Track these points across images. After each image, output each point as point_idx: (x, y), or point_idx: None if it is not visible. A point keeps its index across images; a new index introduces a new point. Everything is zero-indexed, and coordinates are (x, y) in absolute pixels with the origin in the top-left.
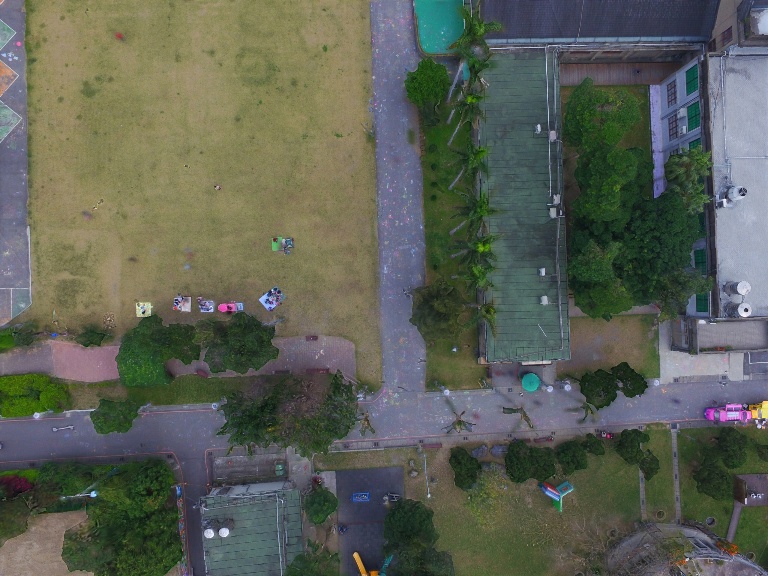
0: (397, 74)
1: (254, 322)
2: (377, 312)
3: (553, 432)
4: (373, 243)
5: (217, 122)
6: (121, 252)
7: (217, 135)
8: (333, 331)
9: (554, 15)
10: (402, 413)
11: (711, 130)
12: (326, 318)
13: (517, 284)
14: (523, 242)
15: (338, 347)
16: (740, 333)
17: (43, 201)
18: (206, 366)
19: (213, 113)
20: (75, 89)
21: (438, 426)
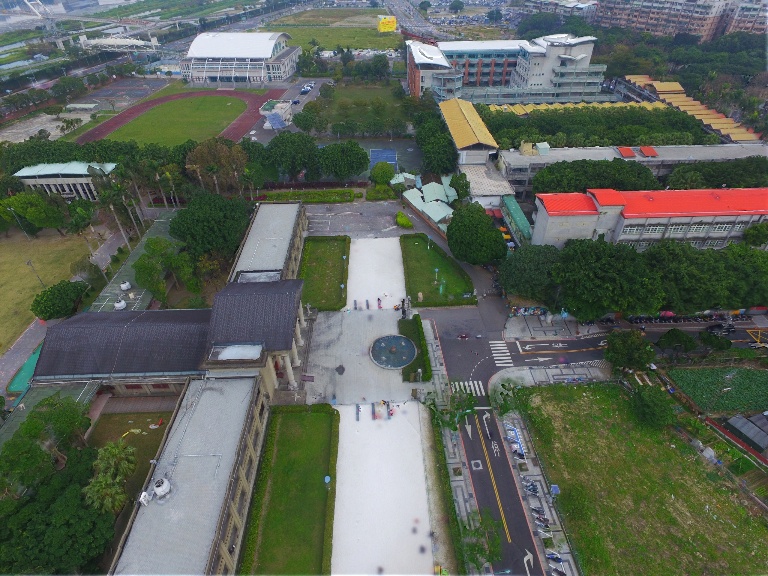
0: None
1: None
2: None
3: None
4: None
5: None
6: None
7: None
8: None
9: (95, 359)
10: None
11: (171, 433)
12: None
13: None
14: None
15: None
16: None
17: None
18: None
19: None
20: None
21: None
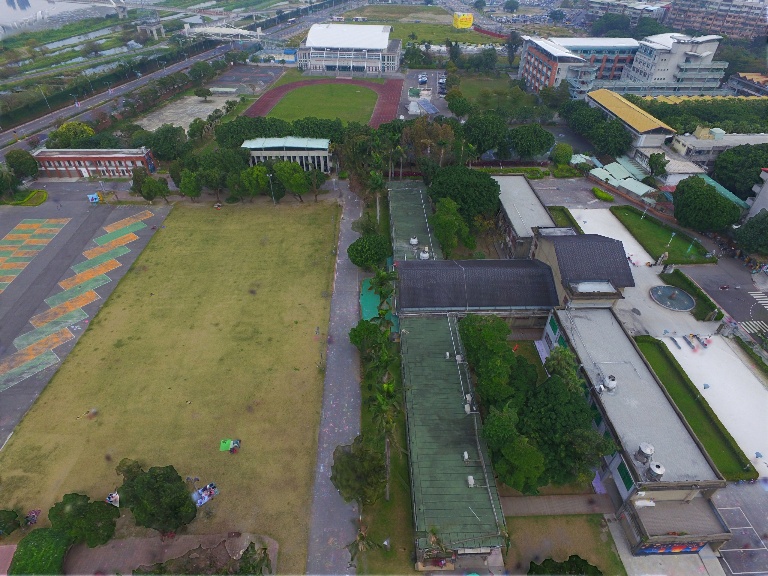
0: (346, 335)
1: None
2: (308, 510)
3: None
4: (313, 446)
5: (205, 361)
6: (81, 452)
7: (202, 369)
8: (259, 529)
9: (448, 295)
10: None
11: (575, 347)
12: (254, 514)
13: (443, 468)
14: (445, 433)
15: None
16: (688, 519)
17: (39, 413)
18: (108, 568)
19: (204, 356)
20: (110, 343)
21: None
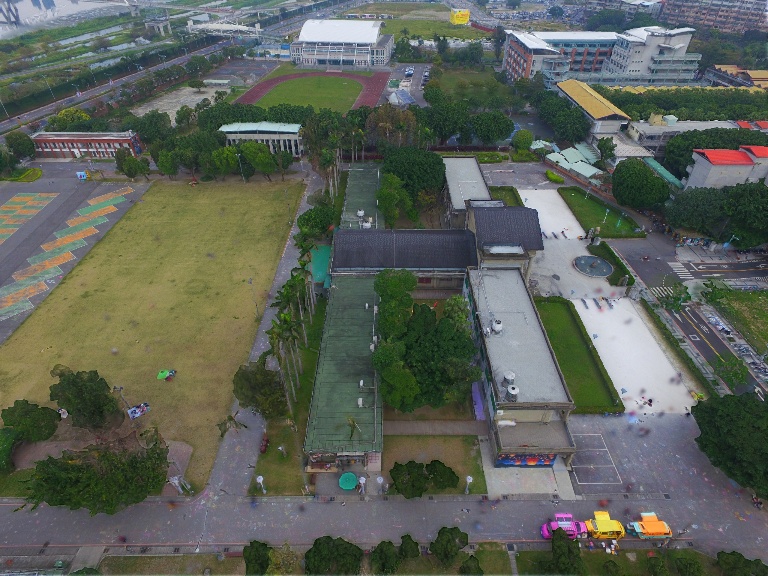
0: None
1: (108, 388)
2: None
3: (374, 547)
4: None
5: (158, 310)
6: (41, 377)
7: (154, 315)
8: (179, 437)
9: (378, 257)
10: (216, 516)
11: (477, 299)
12: (177, 427)
13: (340, 393)
14: (349, 366)
15: (177, 450)
16: (542, 436)
17: (10, 347)
18: None
19: (158, 306)
20: (78, 294)
21: (249, 533)
